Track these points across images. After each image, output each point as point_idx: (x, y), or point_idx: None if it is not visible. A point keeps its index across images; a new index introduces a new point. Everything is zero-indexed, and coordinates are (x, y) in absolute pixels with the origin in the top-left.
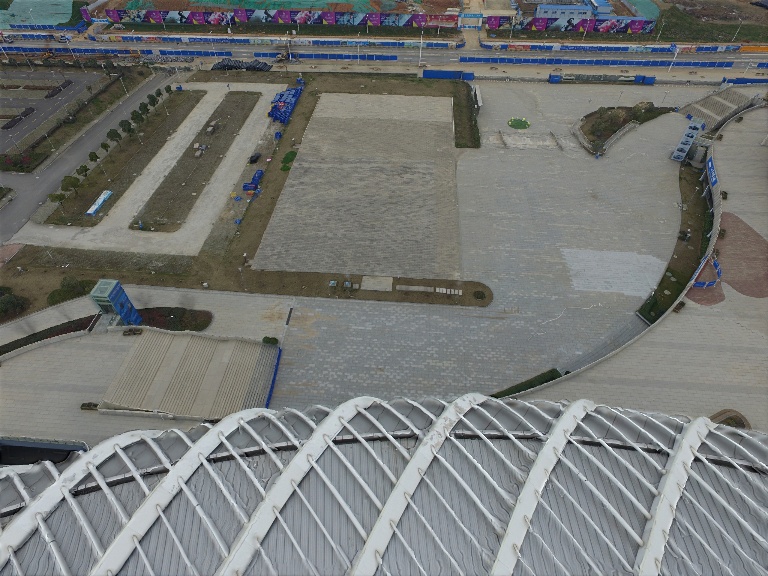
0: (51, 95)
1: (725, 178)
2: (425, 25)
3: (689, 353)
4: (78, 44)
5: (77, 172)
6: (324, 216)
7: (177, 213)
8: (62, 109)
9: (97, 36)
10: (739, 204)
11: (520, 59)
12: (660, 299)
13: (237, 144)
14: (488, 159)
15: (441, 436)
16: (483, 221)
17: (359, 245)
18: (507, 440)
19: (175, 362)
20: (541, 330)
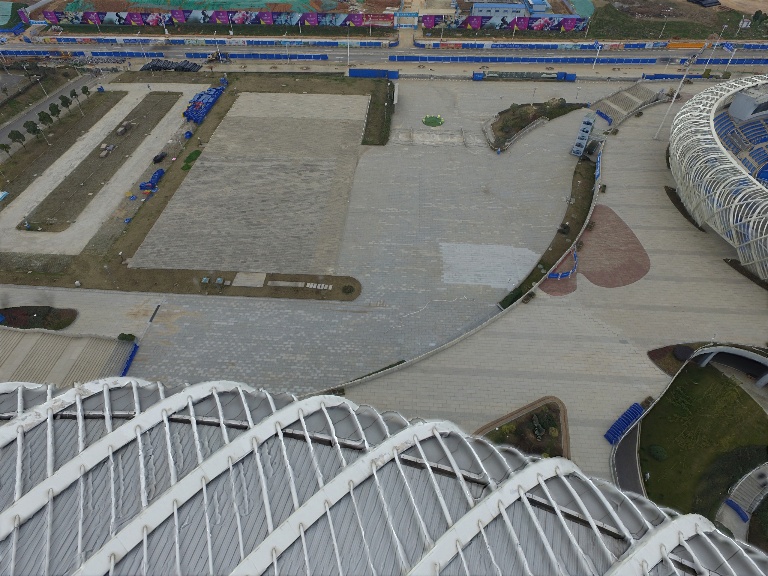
0: None
1: (609, 172)
2: (362, 24)
3: (527, 342)
4: (12, 46)
5: None
6: (213, 214)
7: (68, 213)
8: None
9: (33, 38)
10: (616, 197)
11: (448, 57)
12: (526, 291)
13: (146, 144)
14: (391, 156)
15: (40, 417)
16: (370, 217)
17: (241, 242)
18: (103, 419)
19: (19, 360)
20: (400, 323)
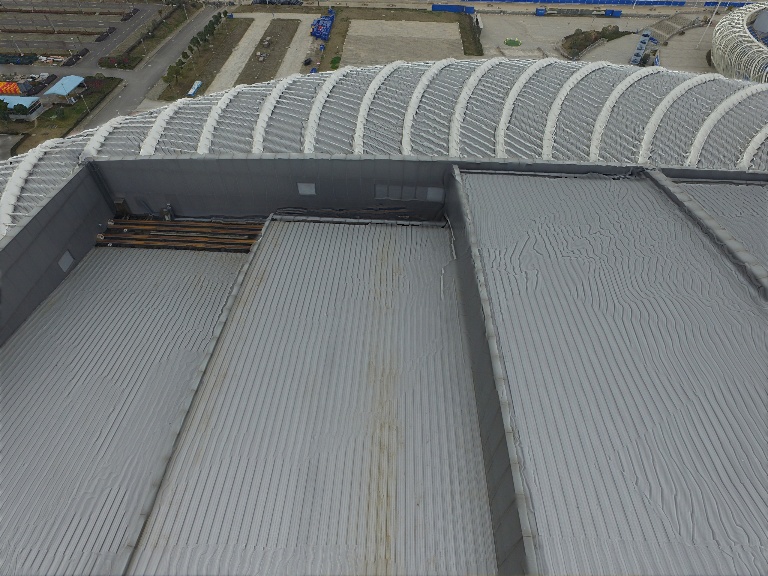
0: (126, 19)
1: None
2: None
3: None
4: None
5: (176, 64)
6: None
7: None
8: (139, 29)
9: None
10: None
11: None
12: None
13: (290, 53)
14: None
15: None
16: None
17: None
18: None
19: None
20: None
